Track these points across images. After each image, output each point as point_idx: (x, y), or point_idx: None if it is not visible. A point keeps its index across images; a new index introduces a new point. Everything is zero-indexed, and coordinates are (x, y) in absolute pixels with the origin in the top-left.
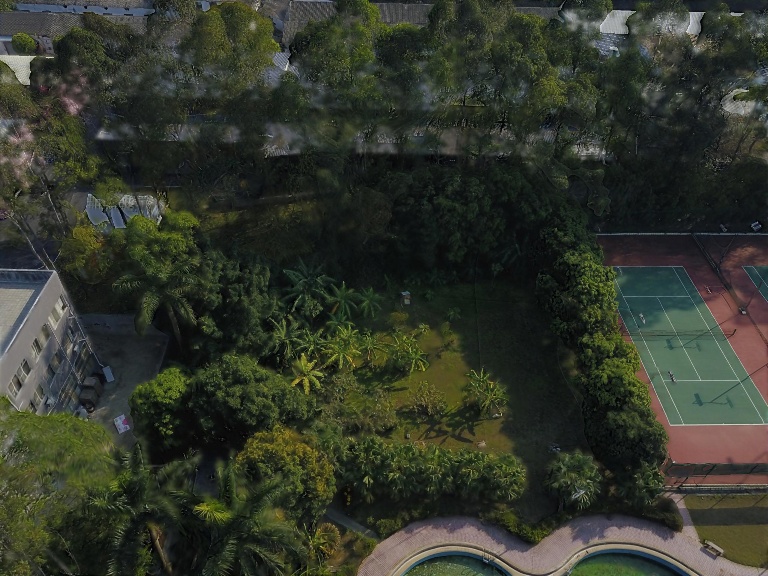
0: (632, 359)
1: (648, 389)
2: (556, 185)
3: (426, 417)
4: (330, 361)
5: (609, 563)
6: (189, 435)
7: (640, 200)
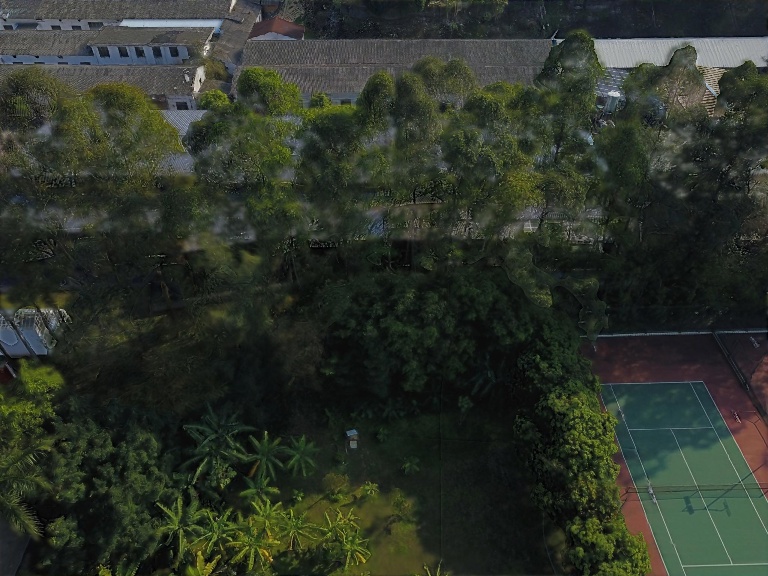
0: (639, 562)
1: None
2: (536, 303)
3: None
4: (237, 559)
5: None
6: None
7: (647, 293)
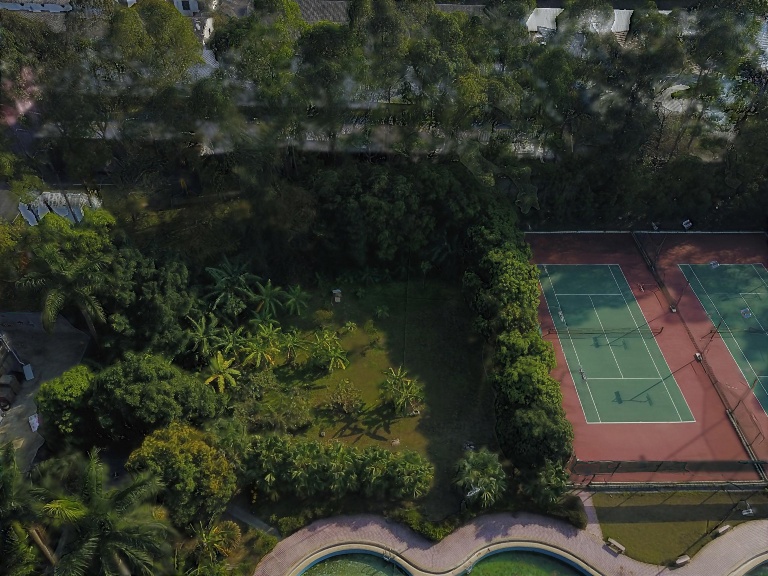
0: (547, 357)
1: (559, 387)
2: (482, 183)
3: (343, 415)
4: (248, 359)
5: (511, 561)
6: (91, 433)
7: (579, 198)
